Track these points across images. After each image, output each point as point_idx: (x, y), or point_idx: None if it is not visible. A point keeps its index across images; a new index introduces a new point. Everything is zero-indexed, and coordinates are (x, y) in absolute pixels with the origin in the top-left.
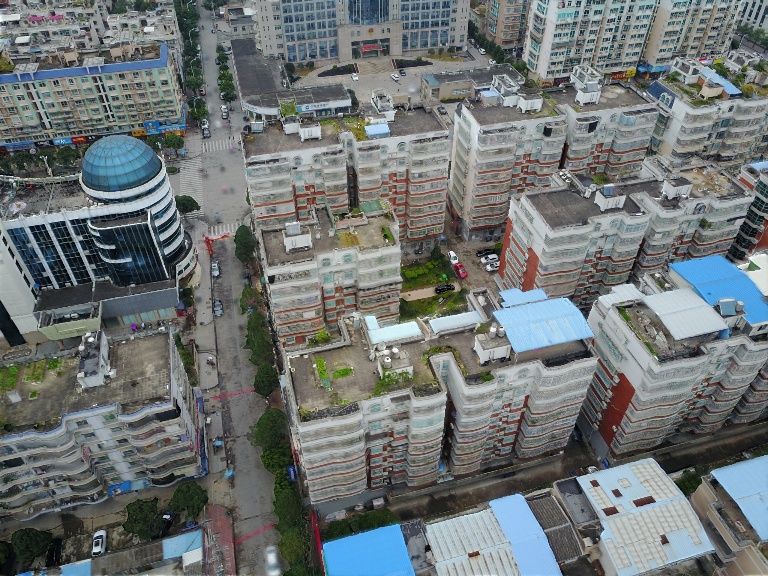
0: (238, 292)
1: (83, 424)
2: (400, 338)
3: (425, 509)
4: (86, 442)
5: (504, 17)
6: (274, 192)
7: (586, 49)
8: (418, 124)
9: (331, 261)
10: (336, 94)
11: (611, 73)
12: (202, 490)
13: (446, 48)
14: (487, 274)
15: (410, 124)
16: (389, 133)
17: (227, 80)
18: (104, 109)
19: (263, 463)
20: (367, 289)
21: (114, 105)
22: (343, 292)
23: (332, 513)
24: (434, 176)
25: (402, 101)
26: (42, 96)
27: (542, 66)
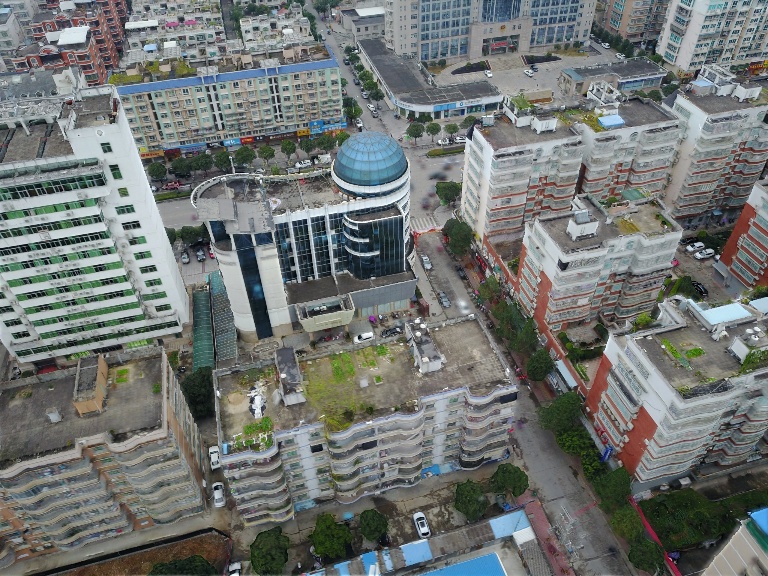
0: (456, 284)
1: (430, 407)
2: (733, 319)
3: (728, 488)
4: (425, 425)
5: (632, 11)
6: (513, 184)
7: (730, 40)
8: (642, 114)
9: (615, 248)
10: (484, 90)
11: (750, 63)
12: None
13: (571, 43)
14: (697, 262)
15: (634, 115)
16: (623, 124)
17: (370, 79)
18: (274, 110)
19: (560, 446)
20: (641, 275)
21: (285, 105)
22: (615, 279)
23: (638, 493)
24: (657, 165)
25: (546, 96)
26: (221, 98)
27: (684, 58)
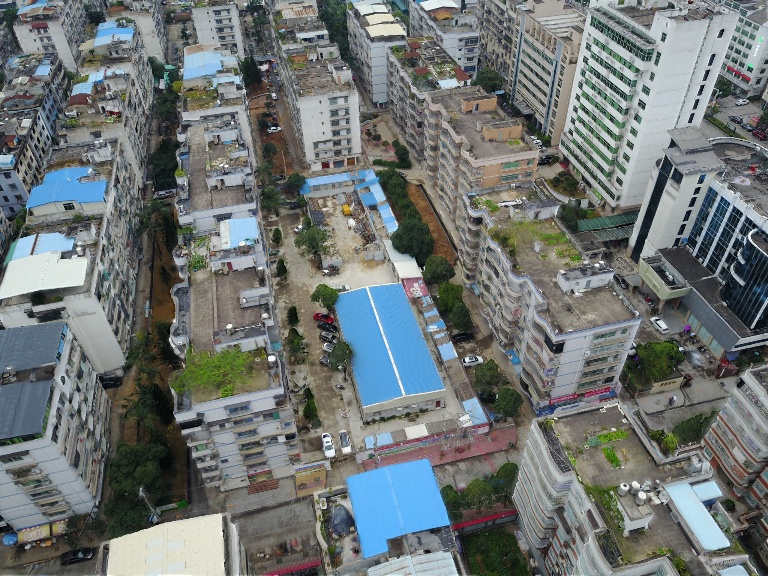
0: None
1: None
2: (688, 521)
3: None
4: (523, 307)
5: None
6: None
7: None
8: None
9: None
10: None
11: None
12: (516, 409)
13: None
14: None
15: None
16: None
17: None
18: None
19: None
20: None
21: None
22: None
23: (524, 536)
24: None
25: None
26: None
27: None
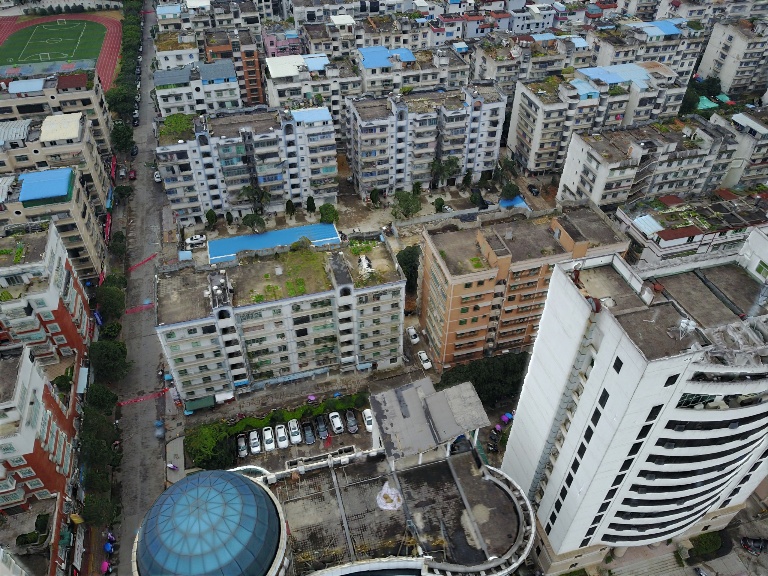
0: None
1: None
2: None
3: None
4: None
5: None
6: None
7: None
8: None
9: None
10: None
11: None
12: None
13: None
14: None
15: None
16: None
17: None
18: None
19: None
20: None
21: None
22: None
23: None
24: None
25: None
26: None
27: None
